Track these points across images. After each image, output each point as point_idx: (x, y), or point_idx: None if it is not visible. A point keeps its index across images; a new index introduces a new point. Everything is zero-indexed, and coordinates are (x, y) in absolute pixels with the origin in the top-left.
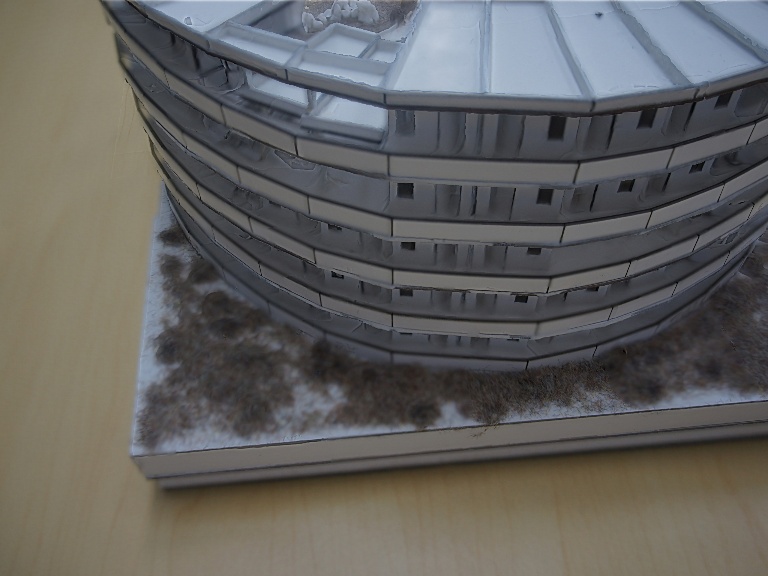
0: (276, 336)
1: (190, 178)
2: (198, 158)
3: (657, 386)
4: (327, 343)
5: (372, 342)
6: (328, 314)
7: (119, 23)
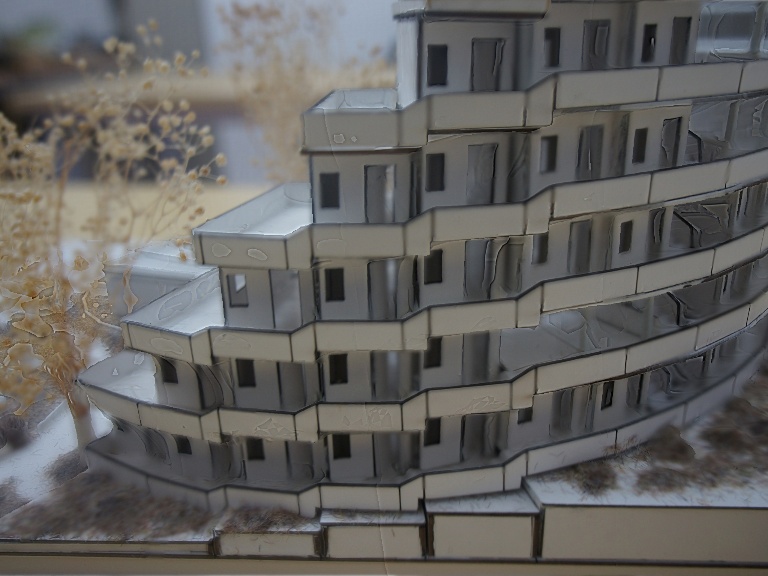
0: (764, 396)
1: (705, 251)
2: (740, 186)
3: None
4: (767, 359)
5: (764, 326)
6: (731, 349)
7: (639, 68)
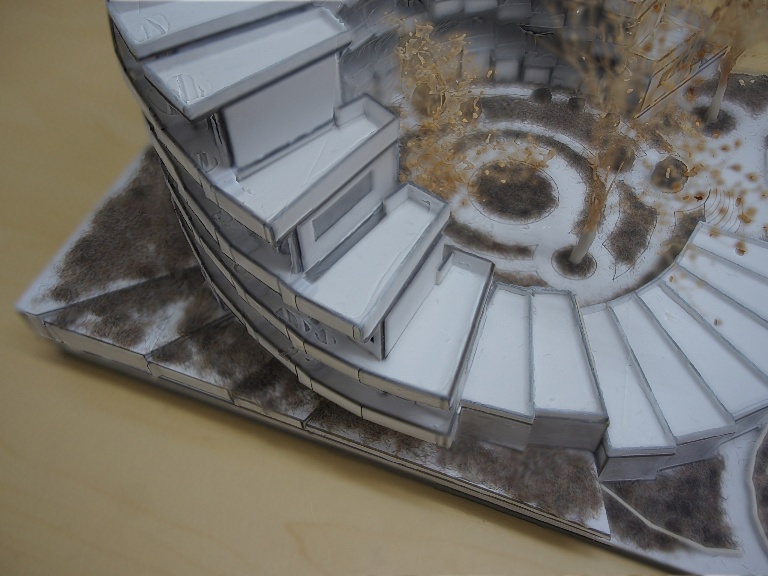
0: None
1: None
2: None
3: (154, 155)
4: None
5: None
6: None
7: None
